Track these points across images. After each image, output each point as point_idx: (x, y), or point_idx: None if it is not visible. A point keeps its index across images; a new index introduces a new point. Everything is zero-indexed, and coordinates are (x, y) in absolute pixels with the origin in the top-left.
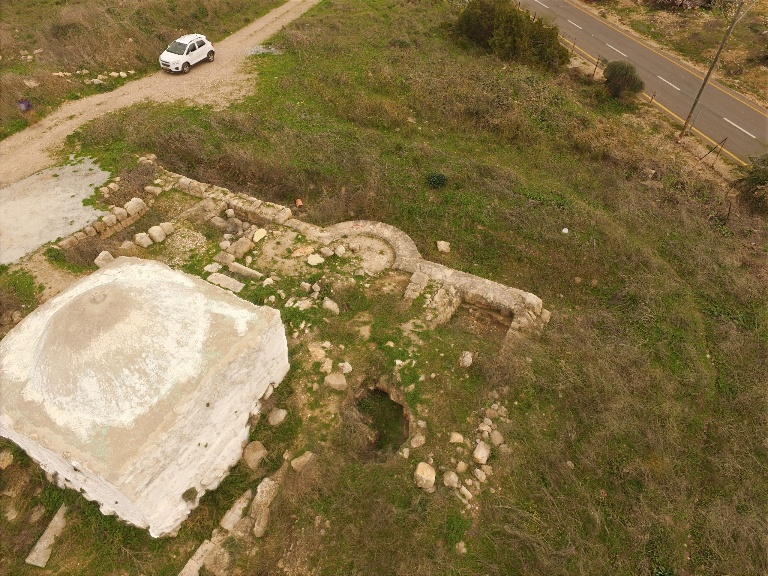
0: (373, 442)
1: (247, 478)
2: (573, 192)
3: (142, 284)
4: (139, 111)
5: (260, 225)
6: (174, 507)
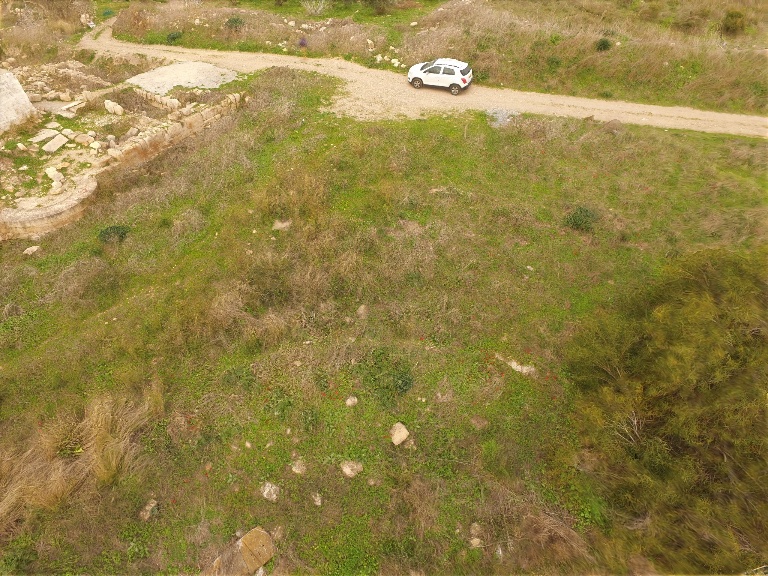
0: None
1: None
2: (8, 370)
3: None
4: (326, 82)
5: None
6: None
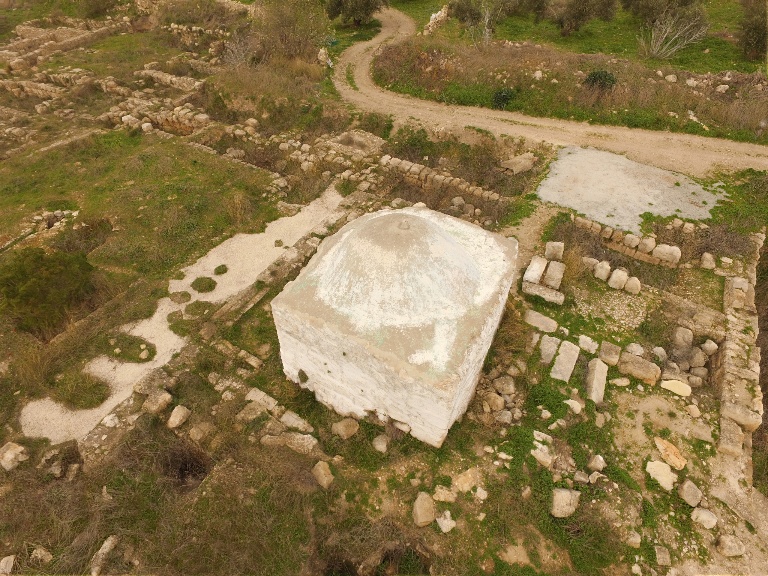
0: (359, 573)
1: (323, 425)
2: None
3: (440, 253)
4: None
5: (708, 388)
6: (293, 366)
